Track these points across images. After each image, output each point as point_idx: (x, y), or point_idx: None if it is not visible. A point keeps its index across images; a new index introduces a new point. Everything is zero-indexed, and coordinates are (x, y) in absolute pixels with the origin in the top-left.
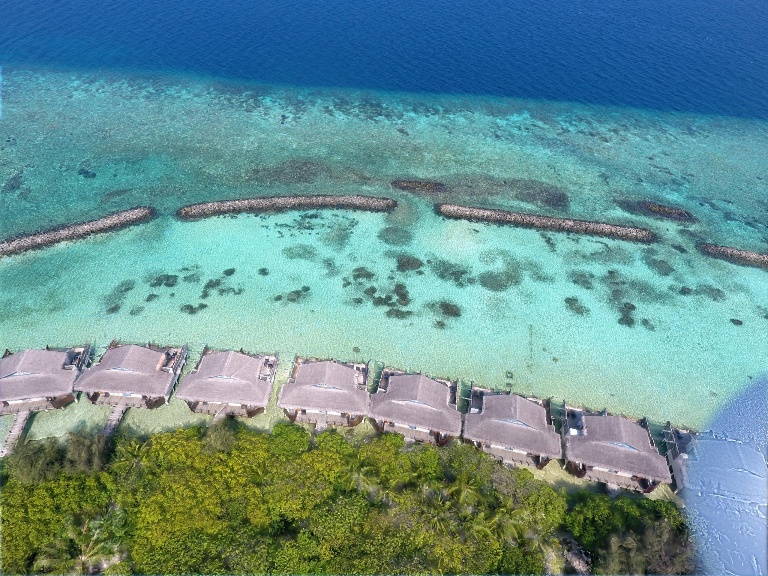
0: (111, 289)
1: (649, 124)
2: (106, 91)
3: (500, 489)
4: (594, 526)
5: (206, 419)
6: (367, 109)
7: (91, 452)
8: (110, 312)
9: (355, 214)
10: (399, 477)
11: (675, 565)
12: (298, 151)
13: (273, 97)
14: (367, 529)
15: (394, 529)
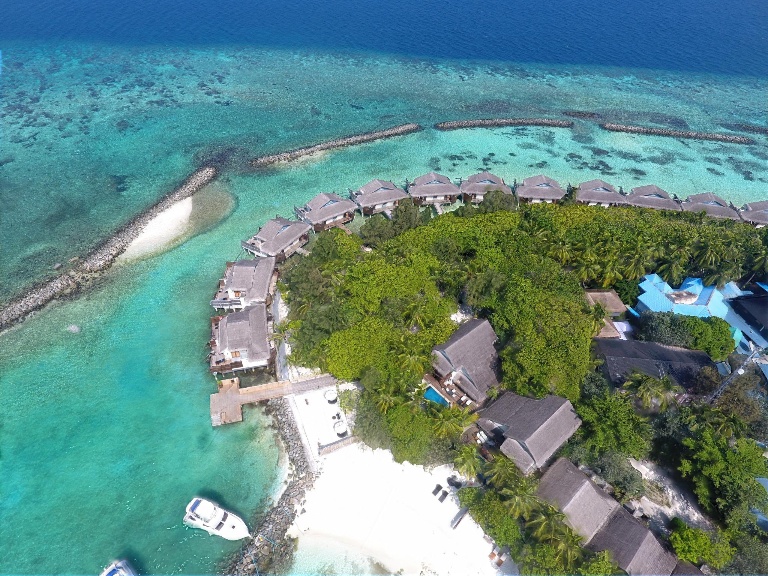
0: (428, 161)
1: (725, 82)
2: (323, 61)
3: None
4: None
5: None
6: (516, 73)
7: (514, 200)
8: (437, 170)
9: (550, 128)
10: None
11: None
12: (487, 96)
13: (444, 65)
14: None
15: None
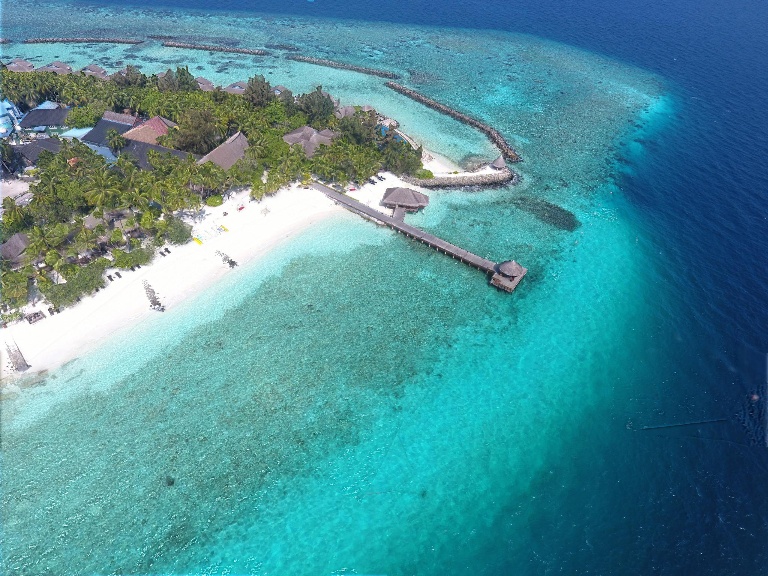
0: None
1: (330, 23)
2: (2, 3)
3: None
4: None
5: None
6: (162, 14)
7: None
8: None
9: (118, 44)
10: None
11: None
12: (105, 26)
13: (107, 8)
14: None
15: None
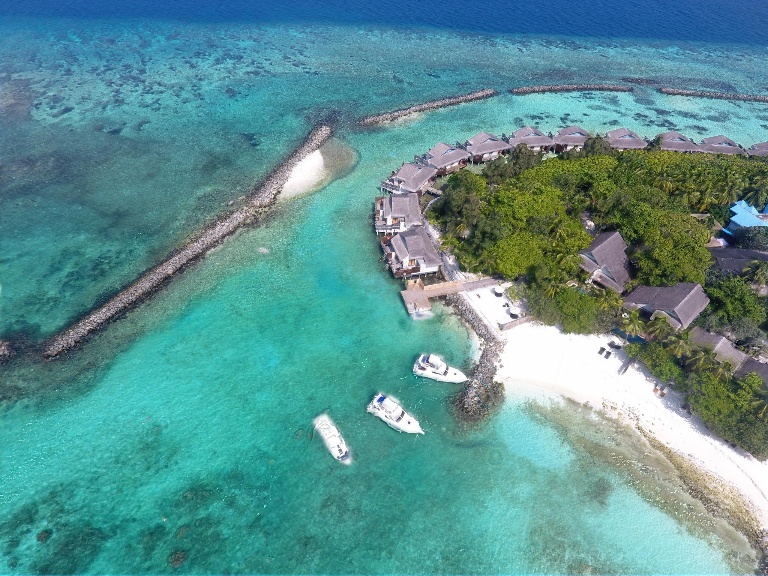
0: (512, 120)
1: (762, 52)
2: (388, 36)
3: None
4: None
5: None
6: (569, 45)
7: None
8: None
9: (613, 93)
10: None
11: None
12: (548, 65)
13: (500, 39)
14: None
15: None
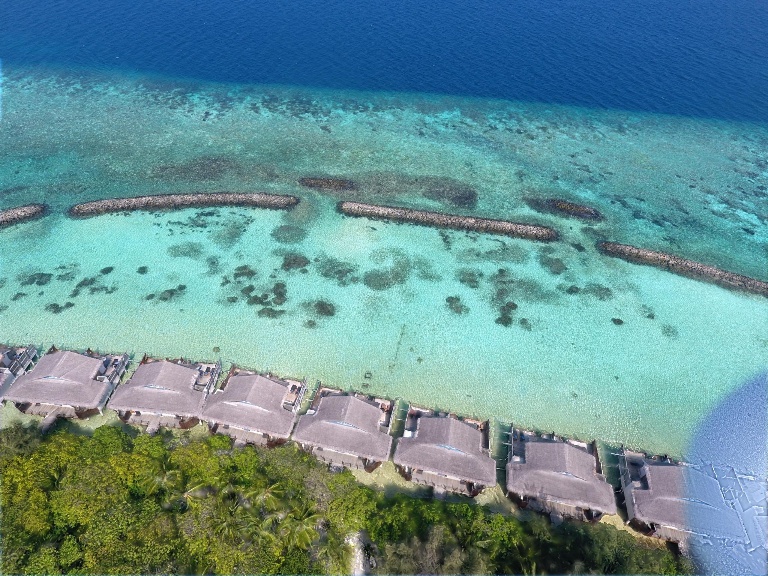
0: None
1: (580, 122)
2: (31, 87)
3: (304, 493)
4: (390, 531)
5: (39, 421)
6: (295, 106)
7: None
8: None
9: (253, 212)
10: (205, 481)
11: (443, 573)
12: (212, 148)
13: (202, 94)
14: (142, 535)
15: (171, 535)
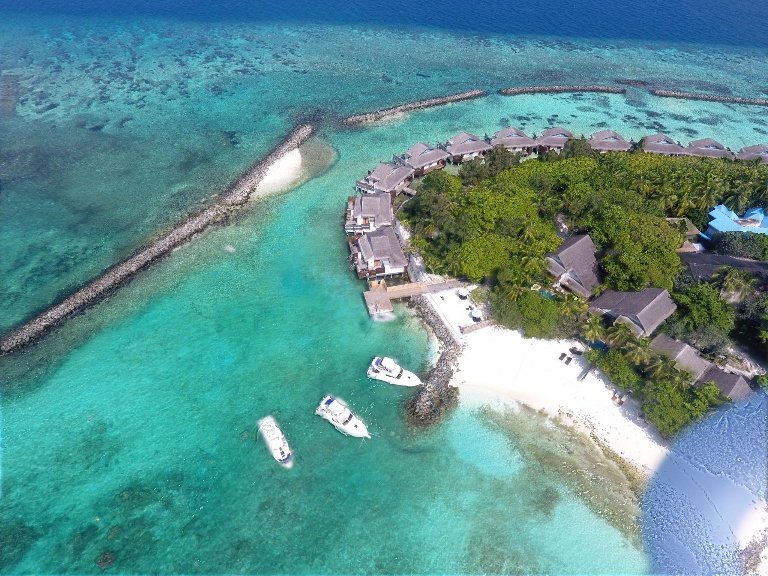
0: (498, 121)
1: (763, 55)
2: (381, 35)
3: None
4: None
5: None
6: (564, 46)
7: None
8: None
9: (604, 94)
10: None
11: None
12: (541, 66)
13: (495, 39)
14: None
15: None
